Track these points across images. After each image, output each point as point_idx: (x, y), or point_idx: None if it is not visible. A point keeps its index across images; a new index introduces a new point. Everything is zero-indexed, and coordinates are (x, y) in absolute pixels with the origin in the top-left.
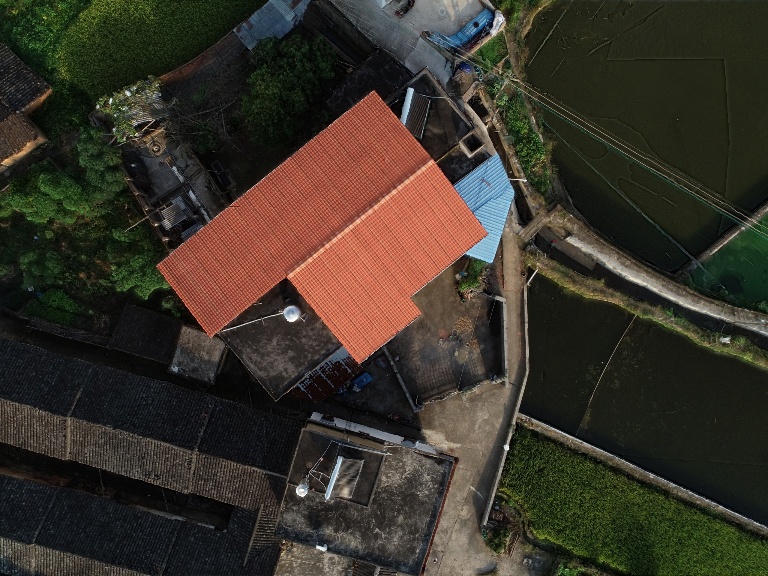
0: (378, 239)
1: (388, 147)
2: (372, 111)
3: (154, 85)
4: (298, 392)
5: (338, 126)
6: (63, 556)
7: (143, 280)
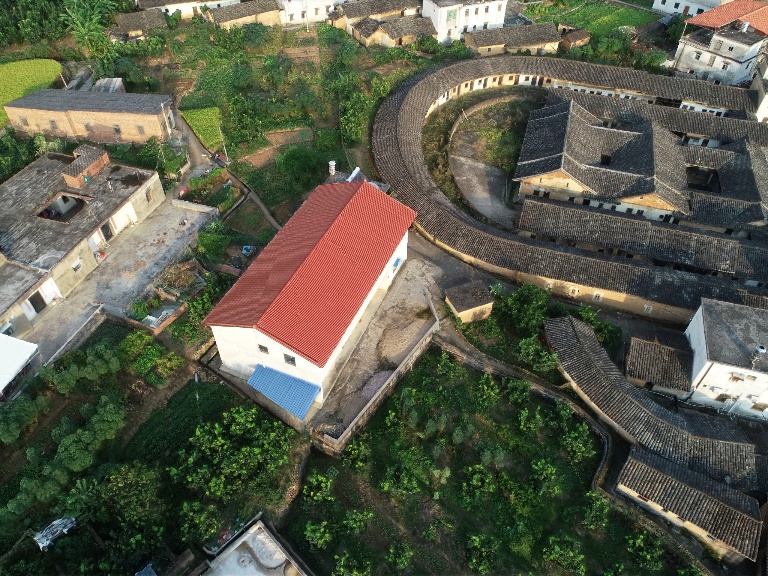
0: (766, 15)
1: (754, 3)
2: (742, 0)
3: (633, 27)
4: (737, 86)
5: (732, 2)
6: (661, 110)
7: (657, 53)
